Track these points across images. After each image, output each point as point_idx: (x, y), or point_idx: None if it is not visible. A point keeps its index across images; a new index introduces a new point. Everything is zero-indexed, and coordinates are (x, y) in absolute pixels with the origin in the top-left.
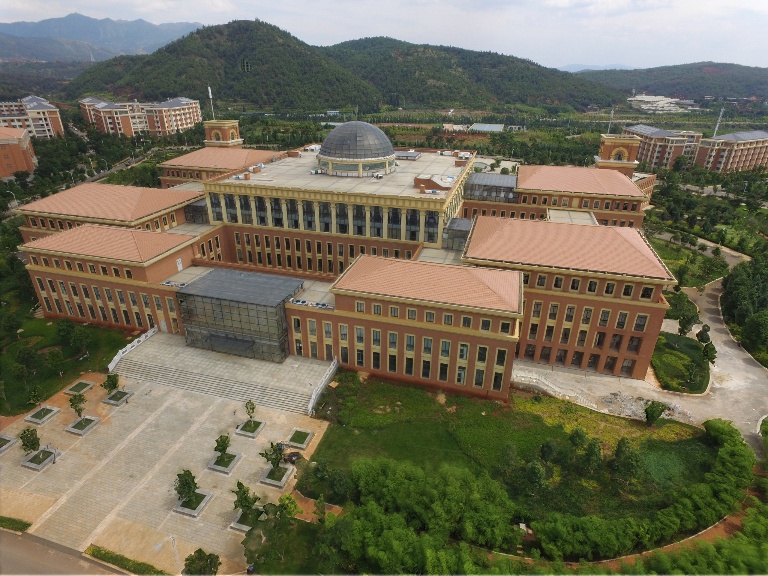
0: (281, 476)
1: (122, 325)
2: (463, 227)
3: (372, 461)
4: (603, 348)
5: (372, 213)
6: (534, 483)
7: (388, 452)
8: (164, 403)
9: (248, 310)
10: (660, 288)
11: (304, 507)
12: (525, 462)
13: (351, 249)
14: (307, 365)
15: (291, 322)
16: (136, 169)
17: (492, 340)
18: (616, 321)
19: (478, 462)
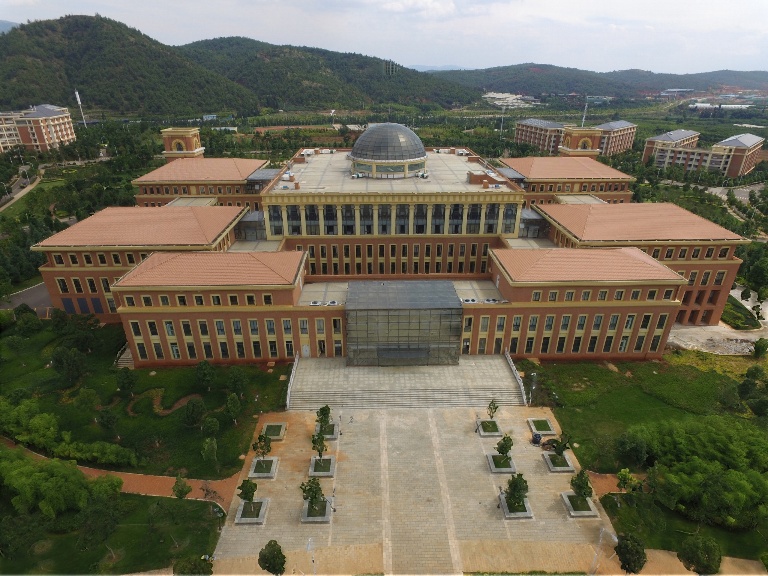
0: (564, 462)
1: (250, 359)
2: (533, 216)
3: (645, 427)
4: (689, 304)
5: (451, 211)
6: (766, 414)
7: (621, 420)
8: (380, 426)
9: (430, 316)
10: (734, 248)
11: (609, 482)
12: (720, 403)
13: (427, 248)
14: (482, 361)
15: (463, 322)
16: (50, 190)
17: (658, 307)
18: (701, 280)
19: (691, 411)
